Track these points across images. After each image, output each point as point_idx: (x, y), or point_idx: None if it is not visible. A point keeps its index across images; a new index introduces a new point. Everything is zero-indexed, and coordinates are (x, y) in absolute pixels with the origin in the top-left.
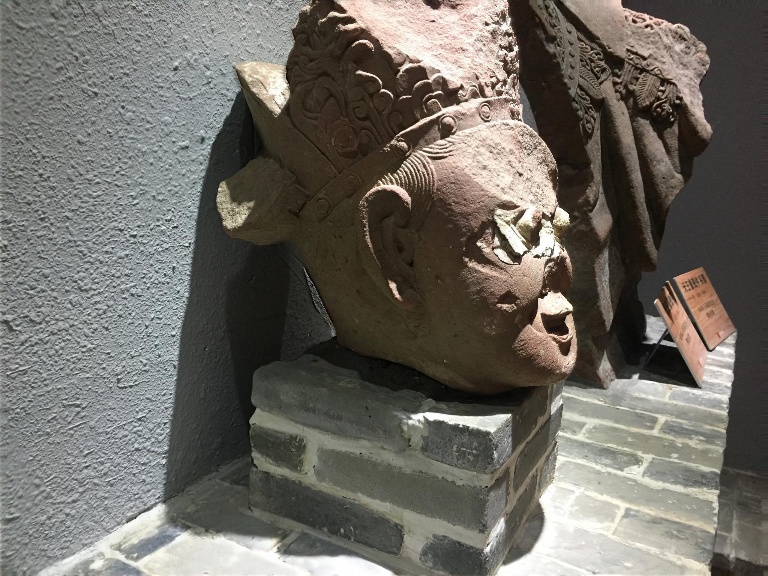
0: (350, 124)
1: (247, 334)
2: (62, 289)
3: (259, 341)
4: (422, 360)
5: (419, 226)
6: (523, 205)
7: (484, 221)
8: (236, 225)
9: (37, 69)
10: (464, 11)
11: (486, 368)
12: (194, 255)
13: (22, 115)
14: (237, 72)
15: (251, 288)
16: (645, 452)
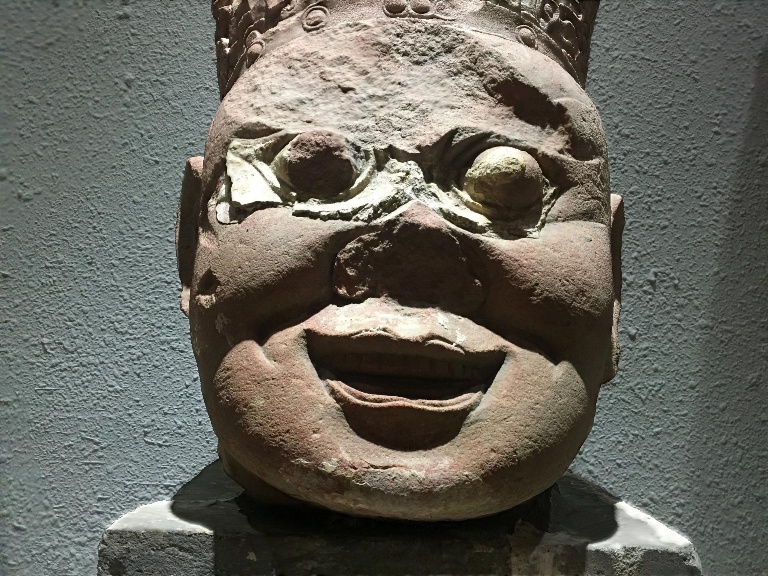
0: None
1: None
2: (99, 327)
3: None
4: None
5: None
6: (298, 129)
7: (217, 163)
8: None
9: (105, 146)
10: None
11: None
12: None
13: (87, 181)
14: None
15: None
16: None
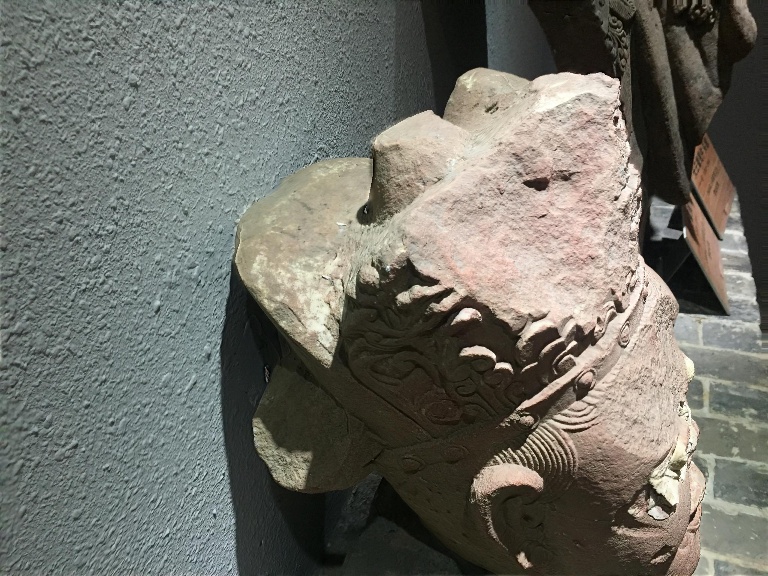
0: (449, 398)
1: None
2: None
3: None
4: None
5: (553, 500)
6: (674, 435)
7: (638, 489)
8: (295, 486)
9: None
10: (583, 185)
11: None
12: (230, 478)
13: None
14: None
15: None
16: (706, 451)
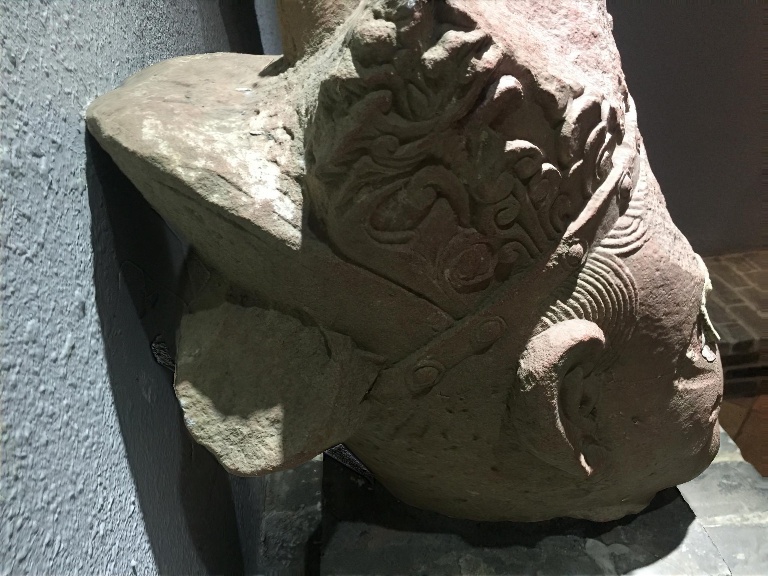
0: (483, 239)
1: (210, 526)
2: None
3: (218, 516)
4: (589, 510)
5: (611, 363)
6: None
7: (695, 321)
8: (266, 464)
9: None
10: None
11: (674, 485)
12: (142, 510)
13: None
14: (143, 161)
15: (194, 463)
16: None
